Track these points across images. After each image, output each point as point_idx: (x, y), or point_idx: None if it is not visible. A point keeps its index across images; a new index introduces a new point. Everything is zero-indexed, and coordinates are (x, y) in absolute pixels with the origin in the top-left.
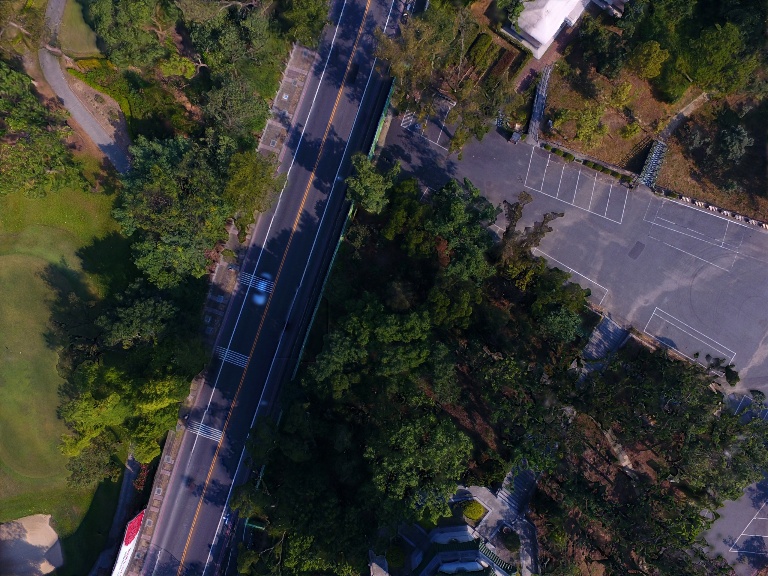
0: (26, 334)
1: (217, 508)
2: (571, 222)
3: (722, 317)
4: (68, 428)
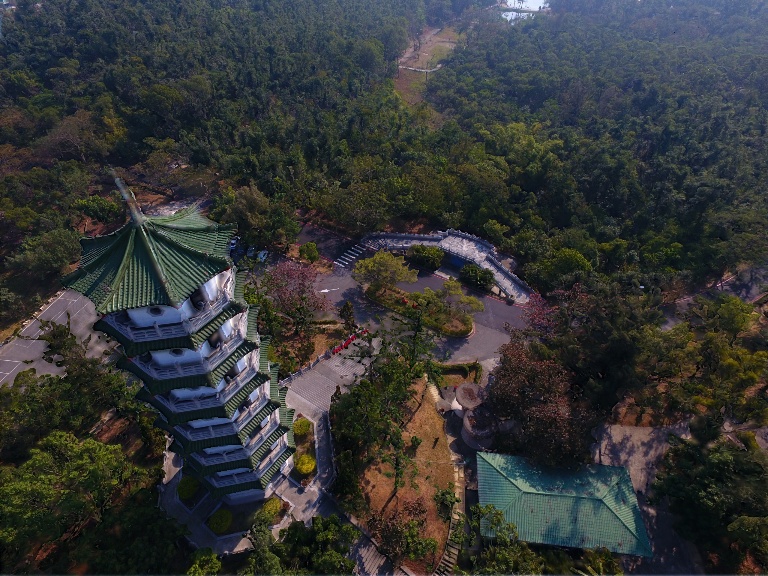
0: None
1: None
2: None
3: None
4: None
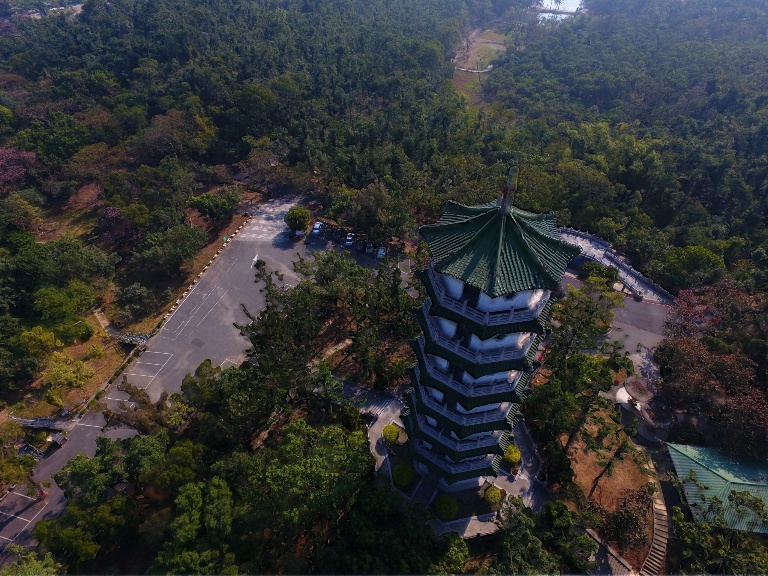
0: None
1: None
2: (160, 389)
3: None
4: None
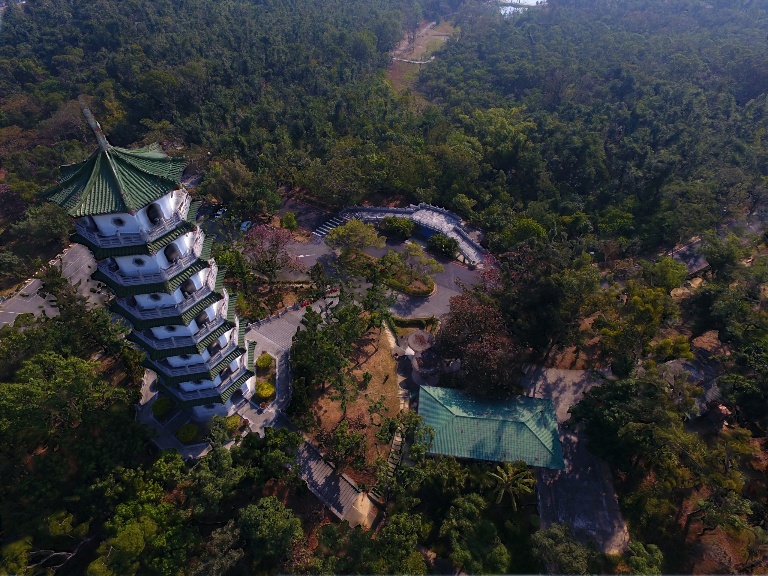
0: None
1: None
2: None
3: None
4: None
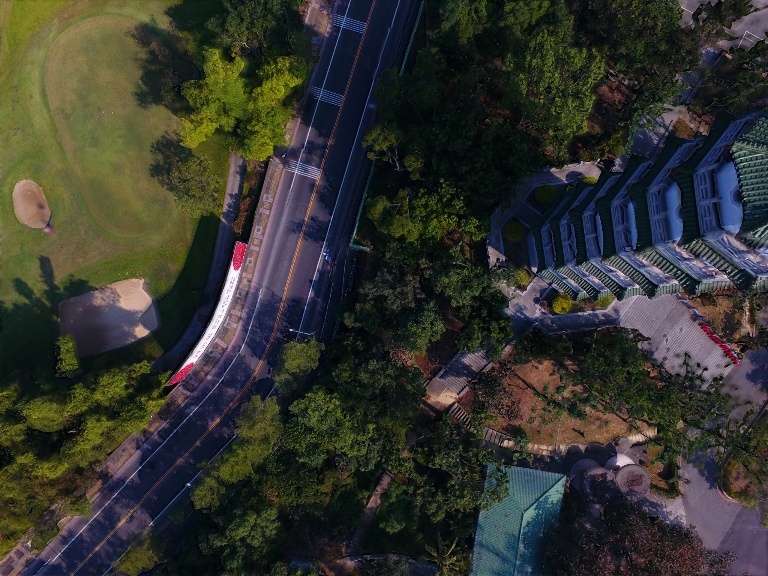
0: (118, 94)
1: (317, 244)
2: None
3: None
4: (162, 186)
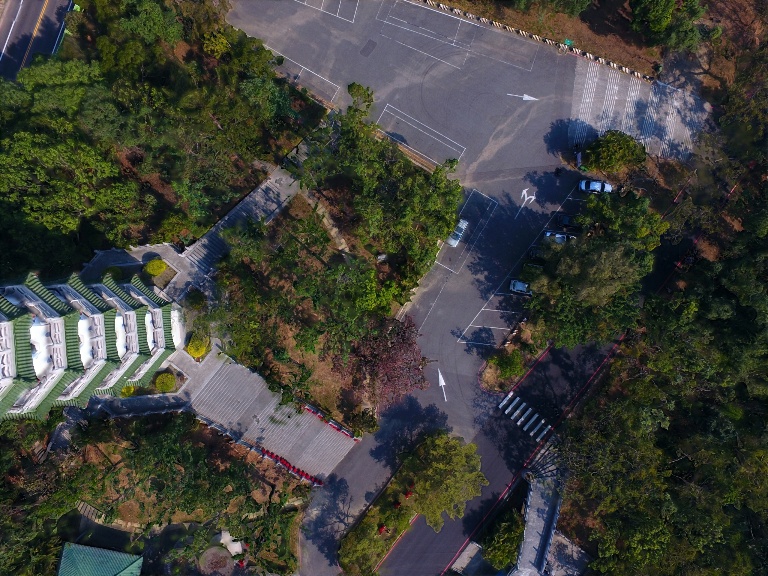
0: None
1: None
2: (303, 21)
3: (453, 113)
4: None
